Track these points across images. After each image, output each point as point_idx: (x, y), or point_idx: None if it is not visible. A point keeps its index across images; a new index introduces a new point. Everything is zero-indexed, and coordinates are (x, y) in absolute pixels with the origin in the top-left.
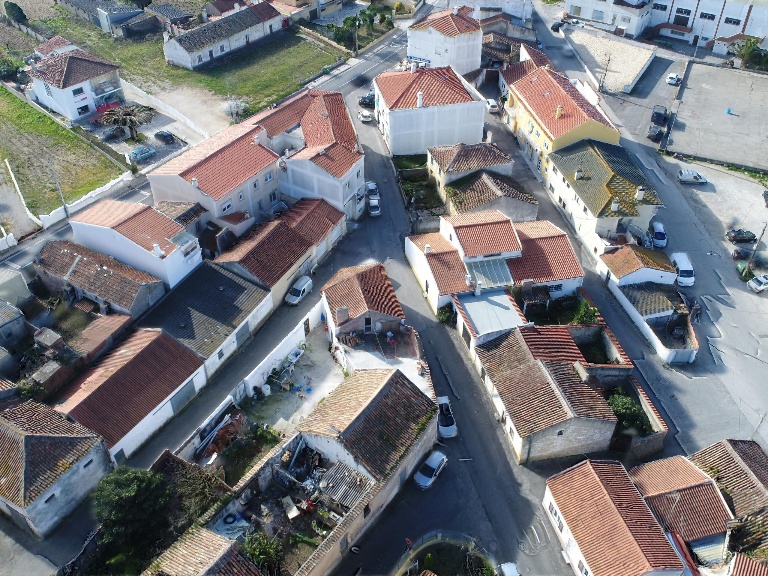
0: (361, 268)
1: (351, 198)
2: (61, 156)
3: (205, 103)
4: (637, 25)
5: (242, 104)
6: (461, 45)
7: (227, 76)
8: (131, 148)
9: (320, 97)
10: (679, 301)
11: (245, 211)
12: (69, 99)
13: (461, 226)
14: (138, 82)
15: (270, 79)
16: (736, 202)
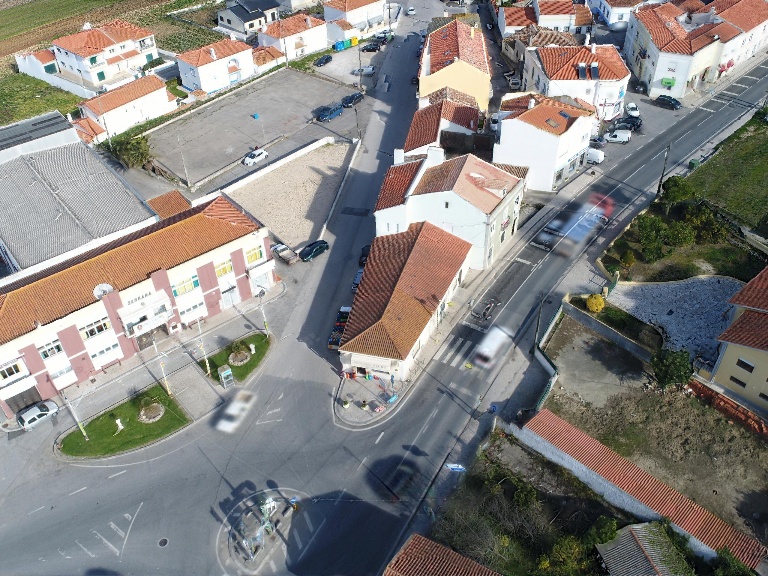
0: (623, 3)
1: None
2: None
3: None
4: None
5: None
6: None
7: None
8: None
9: (678, 38)
10: None
11: None
12: None
13: (567, 0)
14: None
15: (763, 155)
16: None
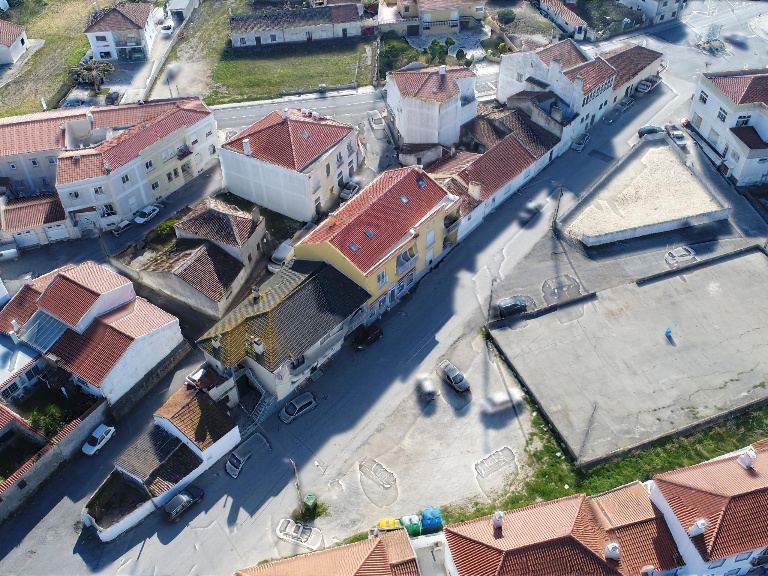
0: None
1: (86, 208)
2: (42, 85)
3: (192, 81)
4: (747, 169)
5: (212, 93)
6: (413, 109)
7: (245, 64)
8: (85, 97)
9: None
10: (174, 478)
11: (20, 180)
12: (93, 42)
13: (65, 276)
14: (187, 46)
15: (268, 79)
16: (458, 435)
